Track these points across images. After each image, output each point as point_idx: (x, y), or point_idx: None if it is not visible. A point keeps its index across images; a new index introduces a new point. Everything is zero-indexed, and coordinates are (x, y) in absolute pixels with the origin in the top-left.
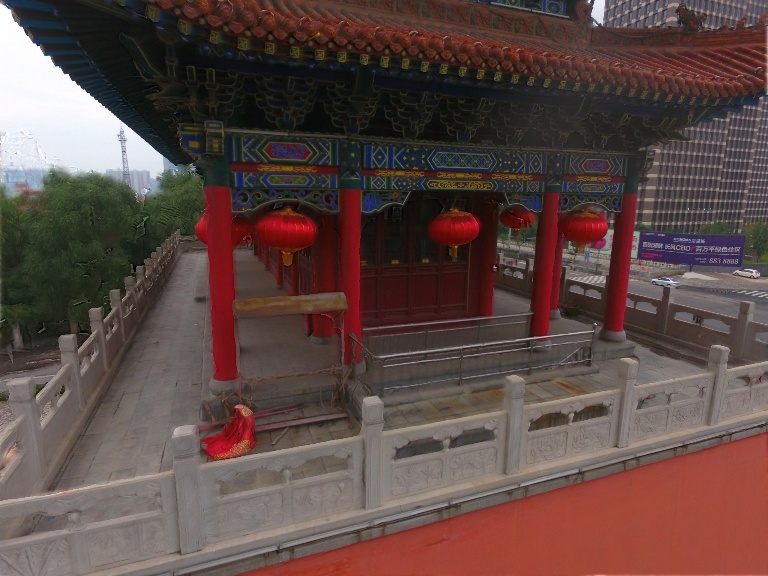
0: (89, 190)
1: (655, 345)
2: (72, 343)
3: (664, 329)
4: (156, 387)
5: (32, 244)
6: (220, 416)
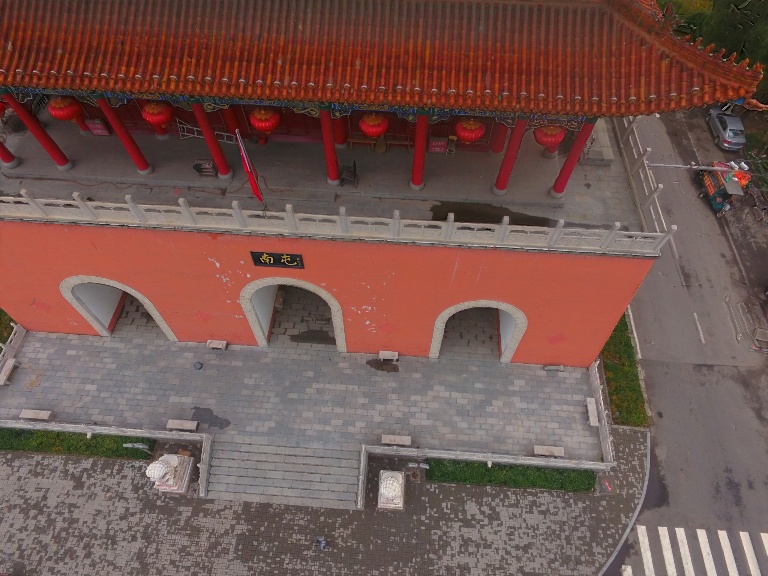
0: None
1: (3, 201)
2: None
3: None
4: None
5: None
6: None
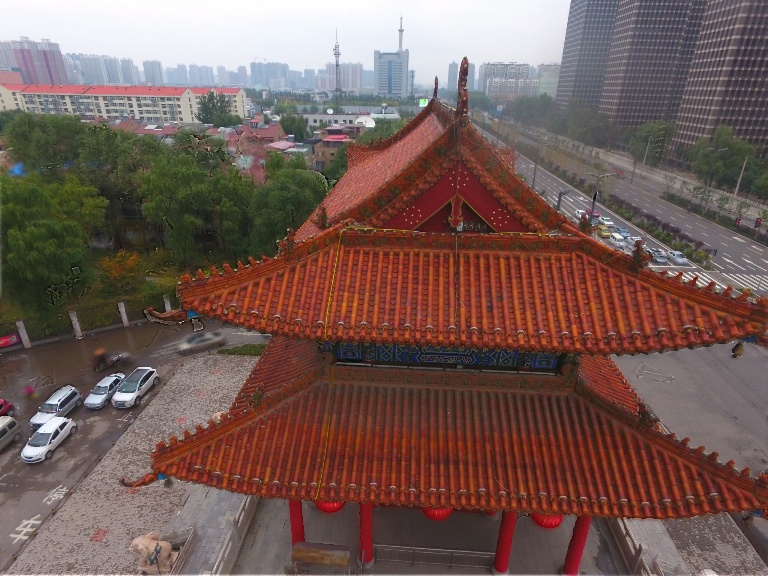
0: (292, 193)
1: None
2: (233, 522)
3: (634, 571)
4: (275, 524)
5: (255, 232)
6: (293, 574)
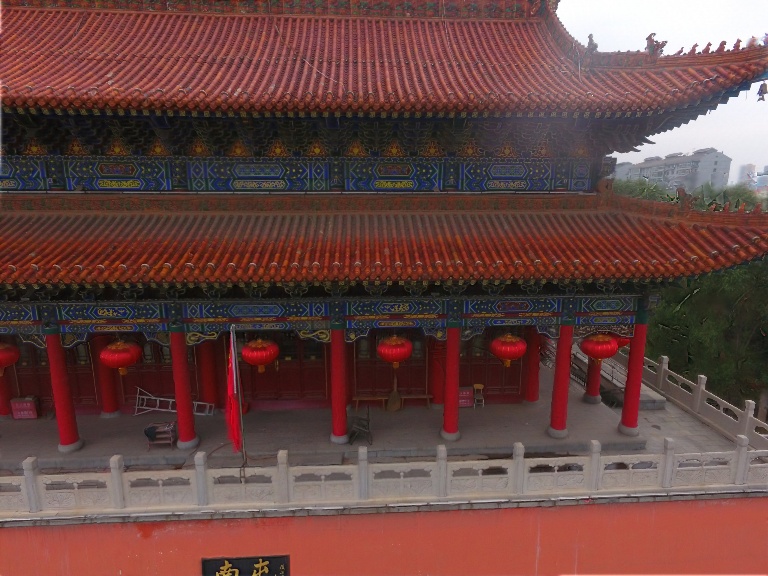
0: None
1: None
2: None
3: None
4: None
5: None
6: None
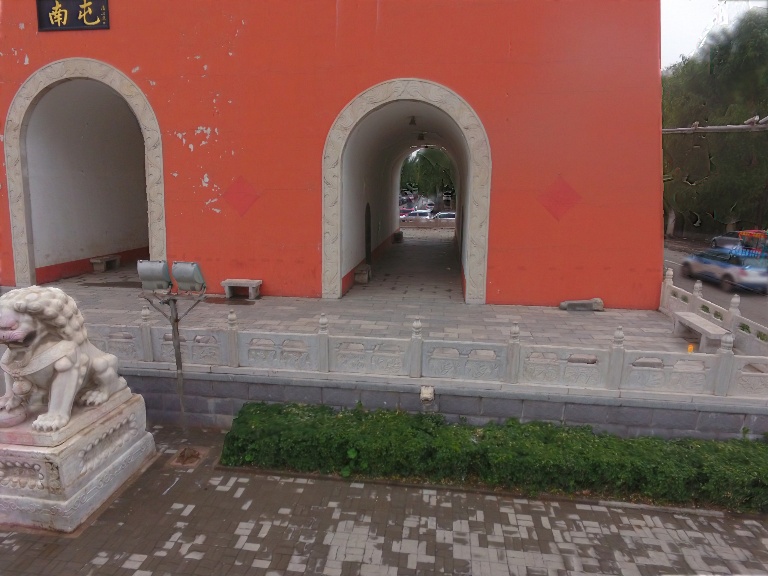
0: (732, 23)
1: None
2: None
3: None
4: None
5: None
6: None
